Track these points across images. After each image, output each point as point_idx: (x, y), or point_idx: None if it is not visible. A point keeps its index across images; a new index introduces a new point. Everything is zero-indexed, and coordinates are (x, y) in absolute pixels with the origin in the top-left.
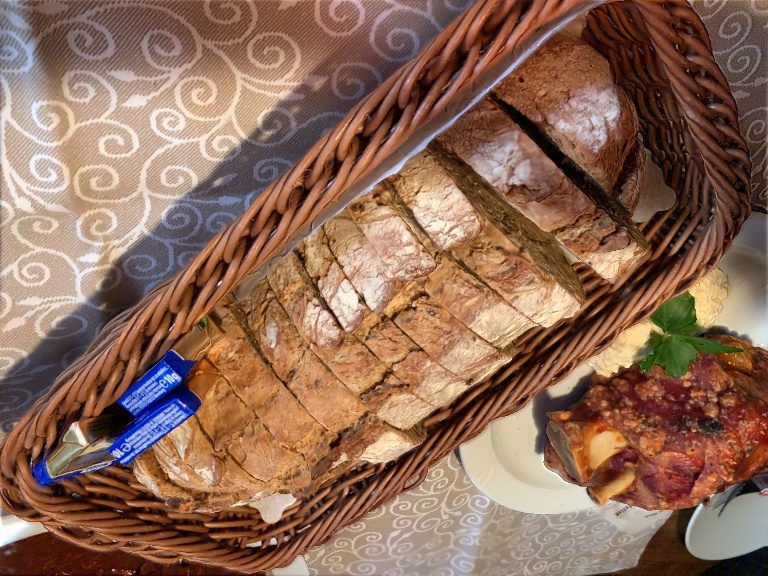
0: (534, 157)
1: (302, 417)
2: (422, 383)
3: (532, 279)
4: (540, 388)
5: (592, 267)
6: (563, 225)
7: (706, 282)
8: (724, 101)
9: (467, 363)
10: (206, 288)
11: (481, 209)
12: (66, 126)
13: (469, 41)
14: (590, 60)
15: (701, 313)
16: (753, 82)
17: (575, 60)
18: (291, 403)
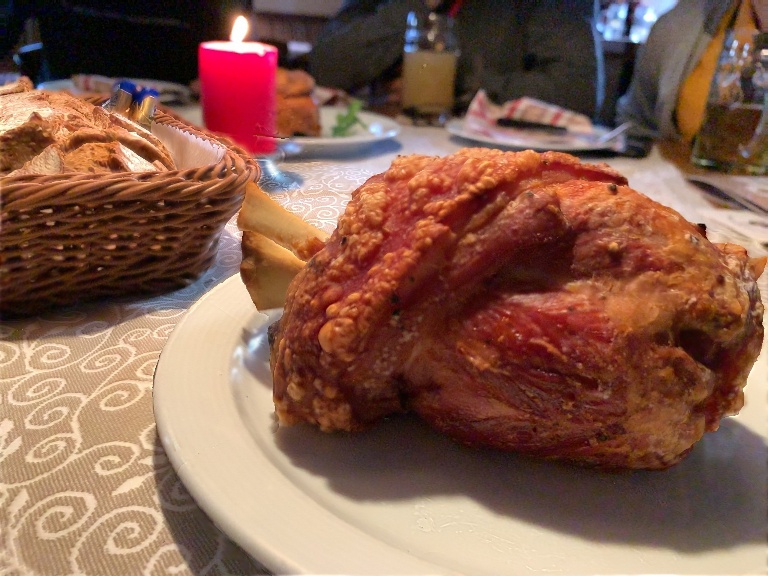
0: None
1: None
2: None
3: None
4: None
5: None
6: None
7: None
8: None
9: None
10: None
11: None
12: None
13: None
14: None
15: None
16: None
17: None
18: None
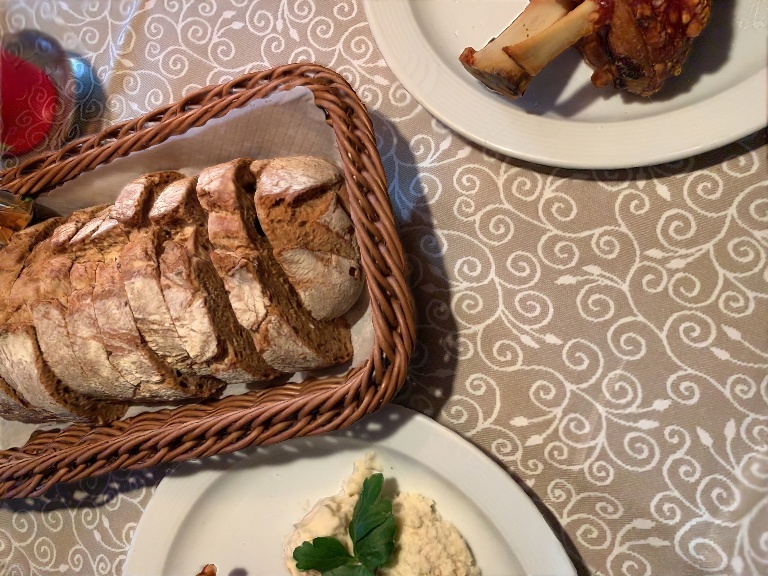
0: (226, 178)
1: (6, 289)
2: (75, 315)
3: (181, 271)
4: (167, 439)
5: (229, 297)
6: (223, 243)
7: (430, 530)
8: (381, 218)
9: (112, 325)
10: (38, 171)
11: (200, 222)
12: (95, 116)
13: (224, 92)
14: (320, 165)
15: (408, 567)
16: (544, 336)
17: (309, 160)
18: (11, 276)
